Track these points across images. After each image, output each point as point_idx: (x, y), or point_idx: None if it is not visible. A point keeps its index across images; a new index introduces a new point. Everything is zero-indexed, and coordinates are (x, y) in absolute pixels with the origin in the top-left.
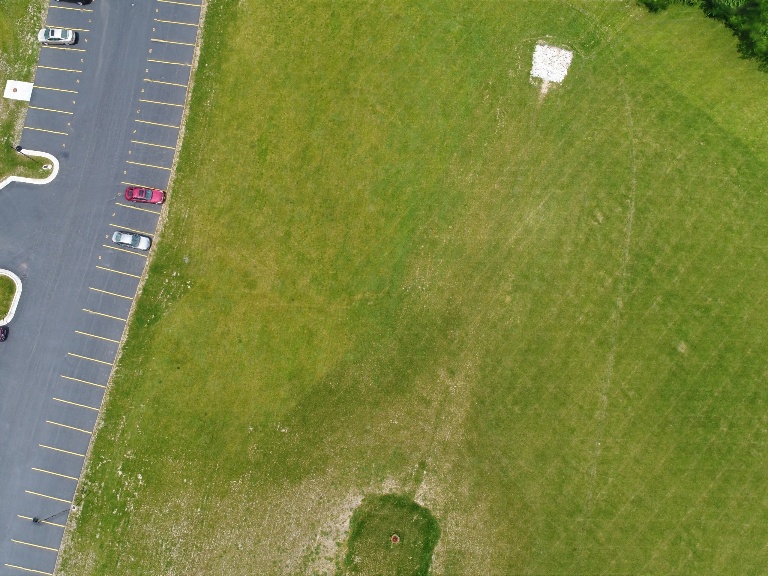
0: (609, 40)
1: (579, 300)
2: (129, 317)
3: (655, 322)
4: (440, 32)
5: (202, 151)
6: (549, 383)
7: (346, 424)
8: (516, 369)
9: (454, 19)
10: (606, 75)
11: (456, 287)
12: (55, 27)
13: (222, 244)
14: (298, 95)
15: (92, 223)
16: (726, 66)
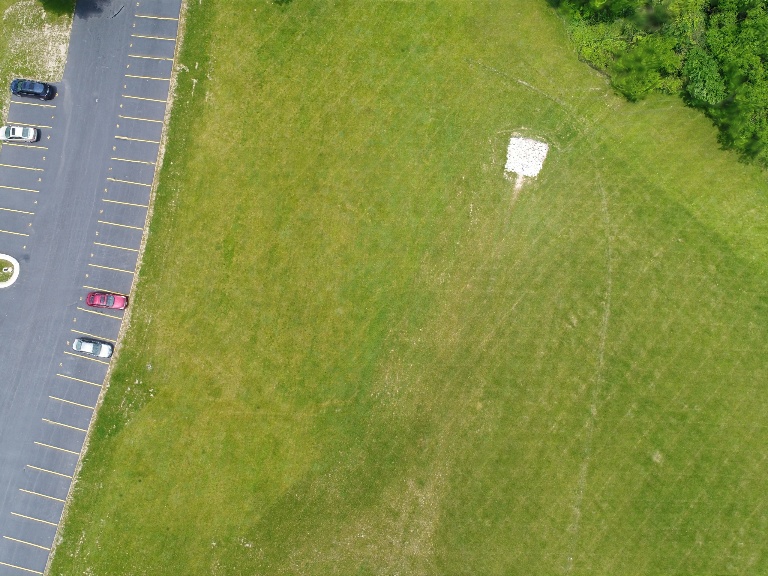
0: (586, 132)
1: (552, 407)
2: (90, 427)
3: (630, 430)
4: (412, 125)
5: (166, 253)
6: (520, 495)
7: (312, 538)
8: (487, 480)
9: (427, 111)
10: (582, 168)
11: (426, 393)
12: (17, 123)
13: (186, 350)
14: (266, 193)
15: (53, 328)
16: (706, 158)
